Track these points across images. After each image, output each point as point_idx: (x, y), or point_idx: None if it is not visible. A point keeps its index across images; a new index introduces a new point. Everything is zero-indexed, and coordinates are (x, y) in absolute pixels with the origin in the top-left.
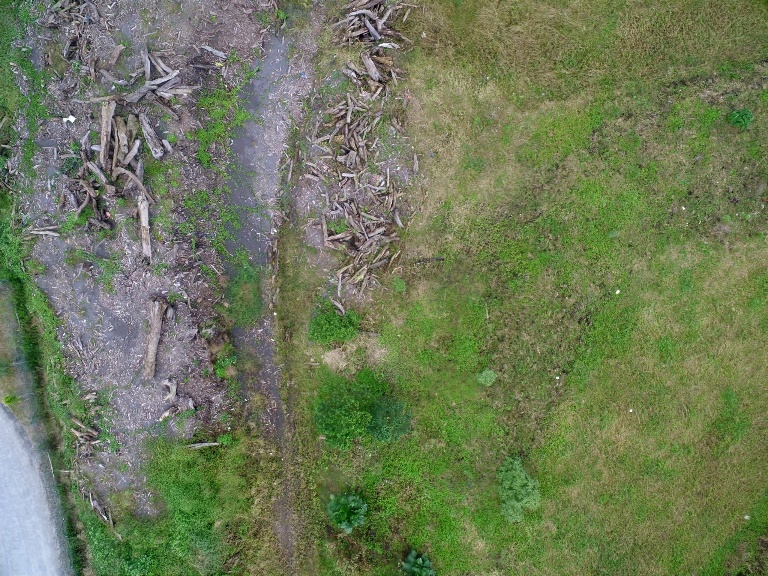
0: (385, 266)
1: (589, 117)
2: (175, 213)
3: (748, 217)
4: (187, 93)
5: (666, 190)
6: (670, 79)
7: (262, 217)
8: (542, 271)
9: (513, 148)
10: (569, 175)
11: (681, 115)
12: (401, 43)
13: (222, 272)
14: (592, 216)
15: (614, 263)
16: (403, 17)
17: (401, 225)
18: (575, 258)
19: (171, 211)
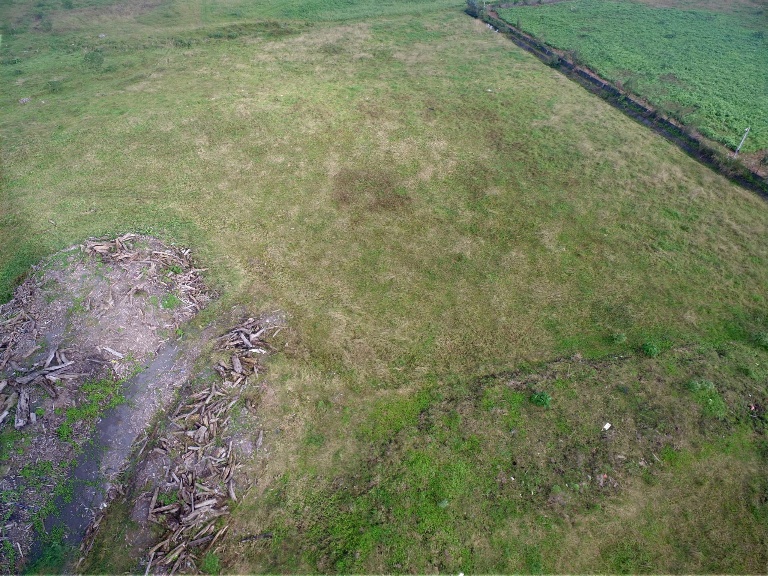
0: (207, 544)
1: (418, 401)
2: (5, 479)
3: (576, 486)
4: (73, 378)
5: (491, 460)
6: (482, 373)
7: (98, 491)
8: (374, 548)
9: (352, 426)
10: (400, 448)
11: (493, 398)
12: (269, 350)
13: (27, 553)
14: (423, 486)
15: (451, 538)
16: (273, 334)
17: (234, 498)
18: (408, 532)
19: (2, 477)
